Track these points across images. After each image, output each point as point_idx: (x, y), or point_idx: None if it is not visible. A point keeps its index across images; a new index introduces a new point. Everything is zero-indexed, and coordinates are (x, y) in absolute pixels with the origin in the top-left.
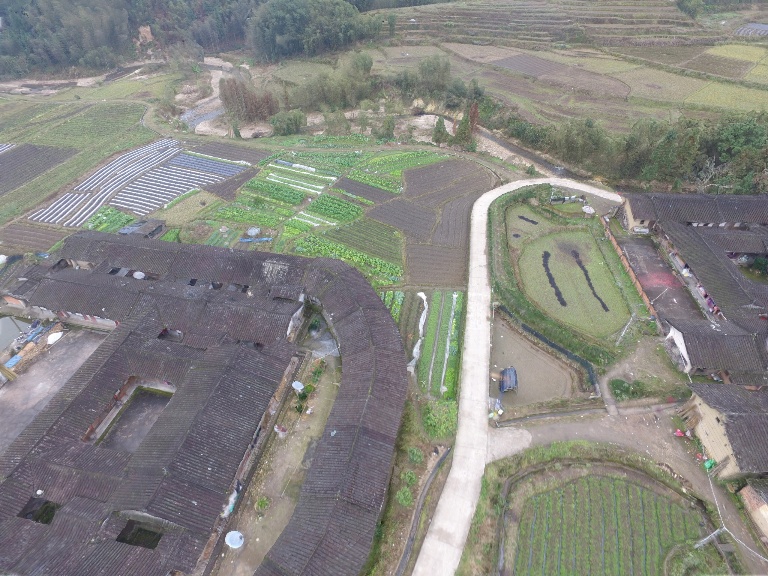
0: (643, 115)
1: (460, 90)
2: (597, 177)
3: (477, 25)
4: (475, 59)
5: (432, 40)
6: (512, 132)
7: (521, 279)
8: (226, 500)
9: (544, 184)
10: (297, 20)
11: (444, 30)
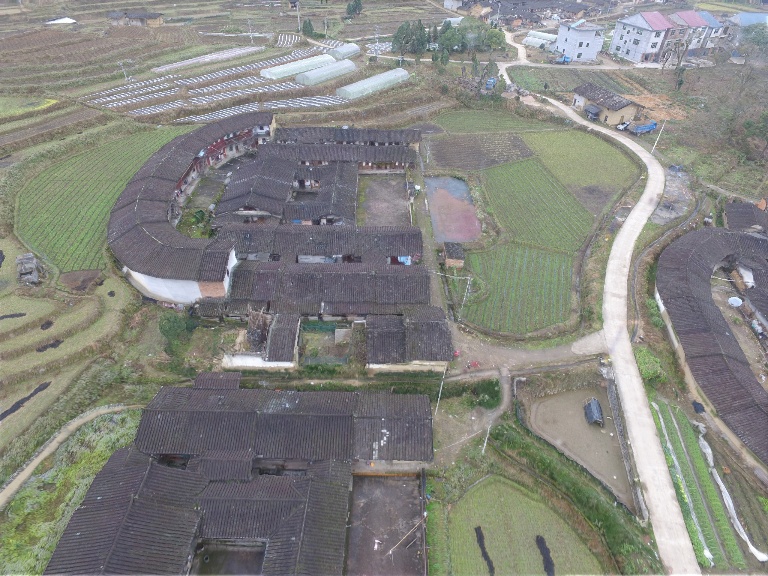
0: None
1: None
2: None
3: None
4: None
5: None
6: None
7: None
8: (762, 325)
9: None
10: None
11: None
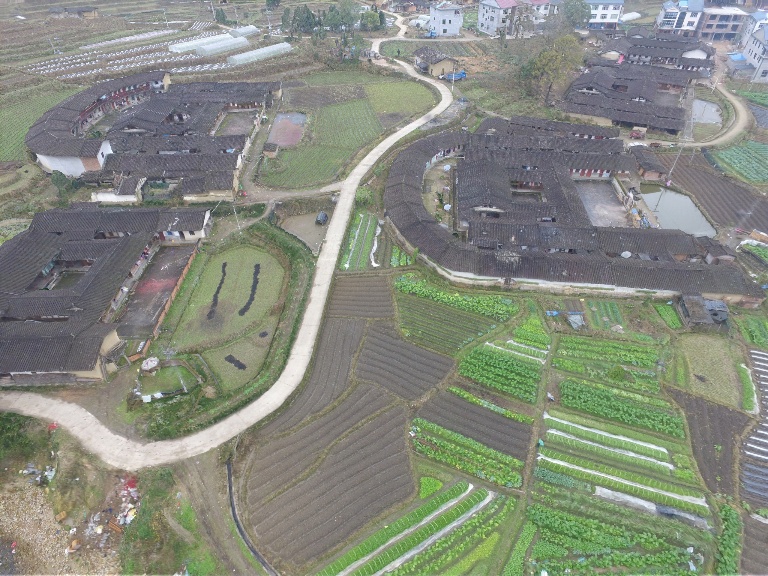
0: None
1: None
2: None
3: None
4: None
5: None
6: None
7: None
8: None
9: (171, 428)
10: None
11: None
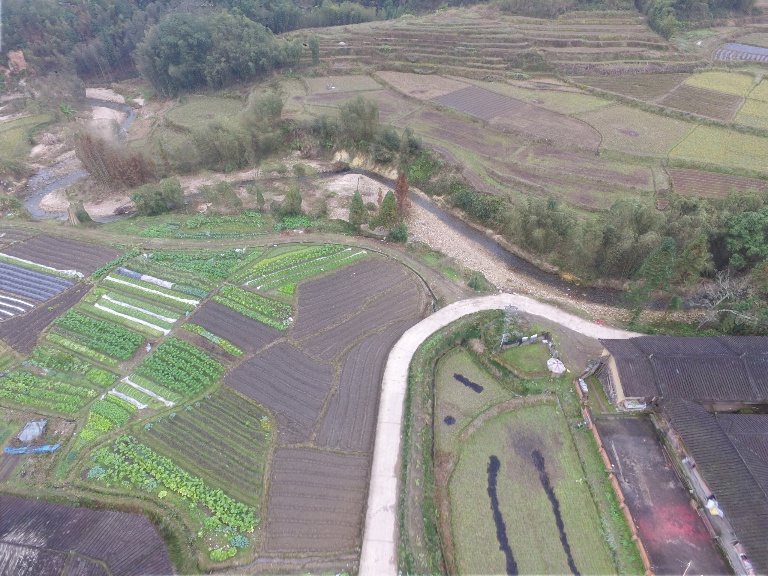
0: (620, 177)
1: (392, 141)
2: (566, 274)
3: (418, 49)
4: (414, 95)
5: (365, 68)
6: (456, 202)
7: (451, 533)
8: None
9: (492, 311)
10: (194, 47)
11: (379, 55)
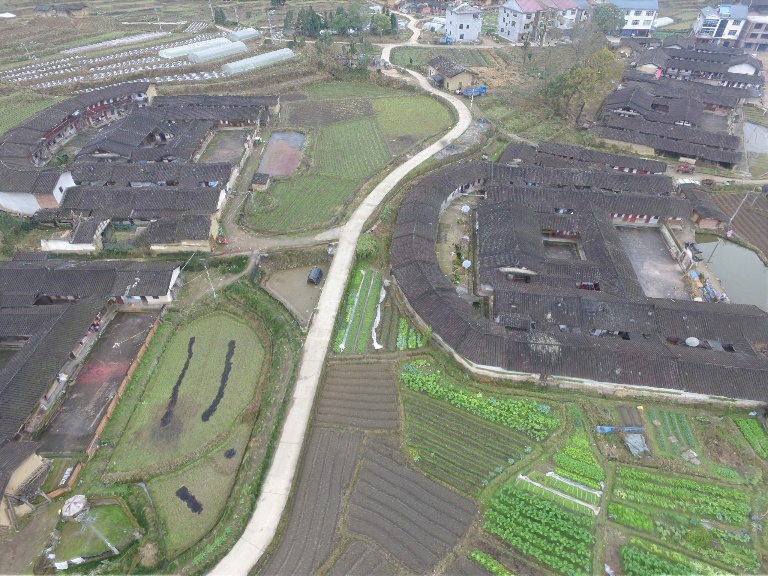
0: None
1: None
2: None
3: None
4: None
5: None
6: None
7: None
8: None
9: None
10: None
11: None
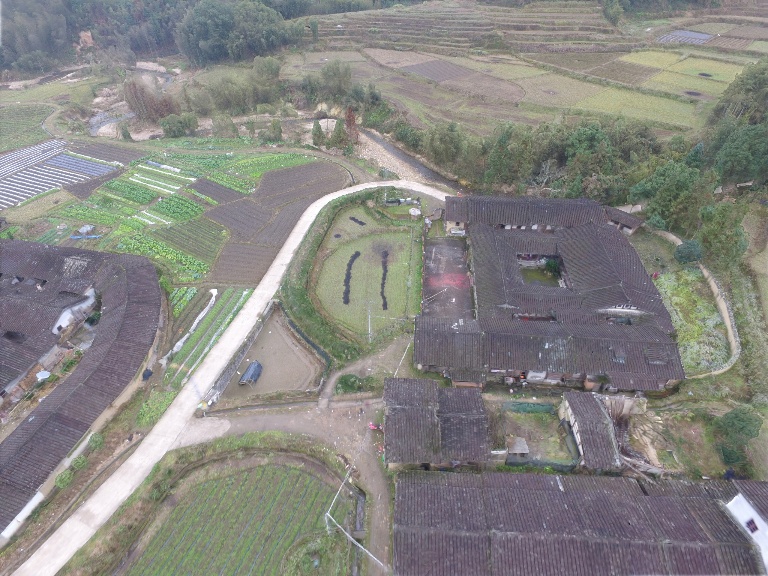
0: (526, 120)
1: (359, 95)
2: (462, 180)
3: (400, 31)
4: (388, 64)
5: (355, 46)
6: (397, 136)
7: (317, 278)
8: None
9: (387, 186)
10: (220, 26)
11: (368, 36)
